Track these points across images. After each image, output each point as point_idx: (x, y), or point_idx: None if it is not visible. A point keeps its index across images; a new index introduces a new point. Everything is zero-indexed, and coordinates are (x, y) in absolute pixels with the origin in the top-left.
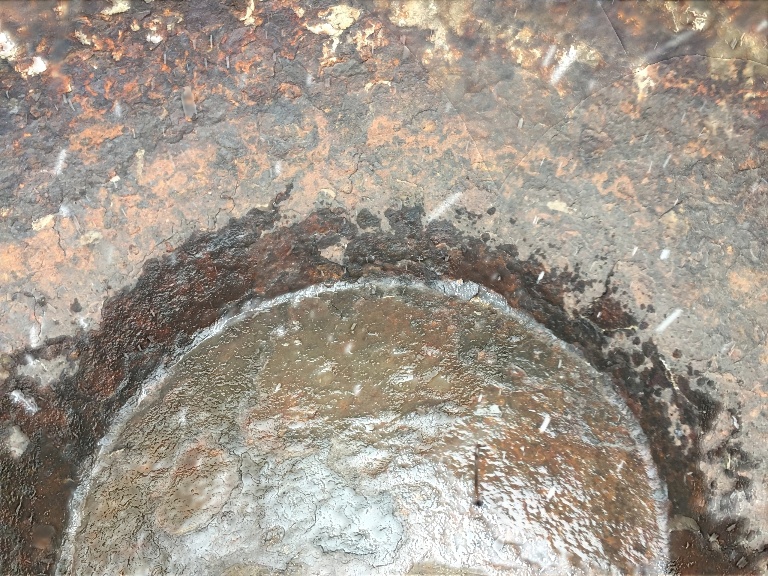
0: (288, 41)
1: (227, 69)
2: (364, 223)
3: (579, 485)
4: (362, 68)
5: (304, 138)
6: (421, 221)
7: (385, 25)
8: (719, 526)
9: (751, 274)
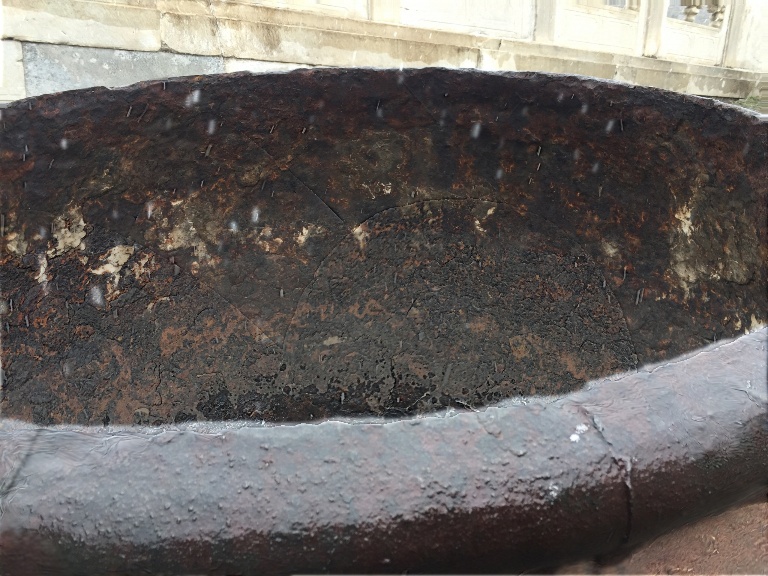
0: (76, 287)
1: (27, 328)
2: (183, 425)
3: None
4: (142, 293)
5: (106, 370)
6: (230, 401)
7: (156, 252)
8: None
9: (481, 318)
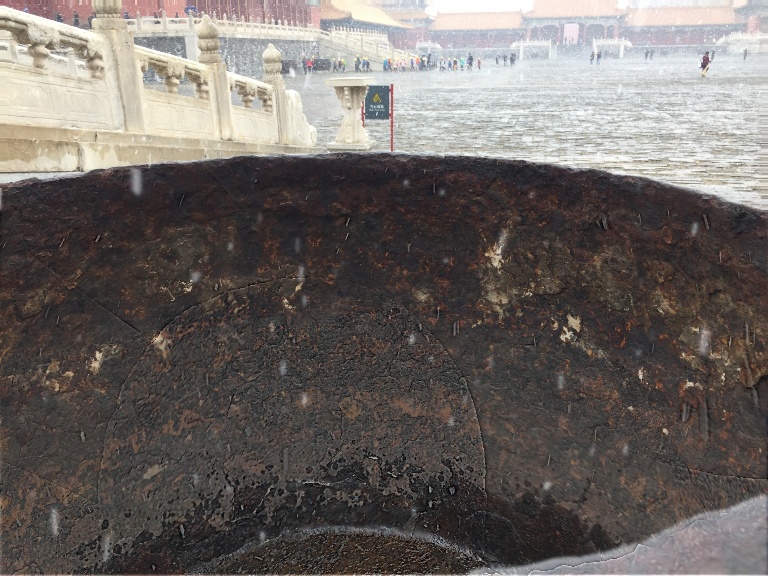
0: None
1: None
2: None
3: (369, 573)
4: None
5: None
6: None
7: None
8: (426, 497)
9: (305, 393)
